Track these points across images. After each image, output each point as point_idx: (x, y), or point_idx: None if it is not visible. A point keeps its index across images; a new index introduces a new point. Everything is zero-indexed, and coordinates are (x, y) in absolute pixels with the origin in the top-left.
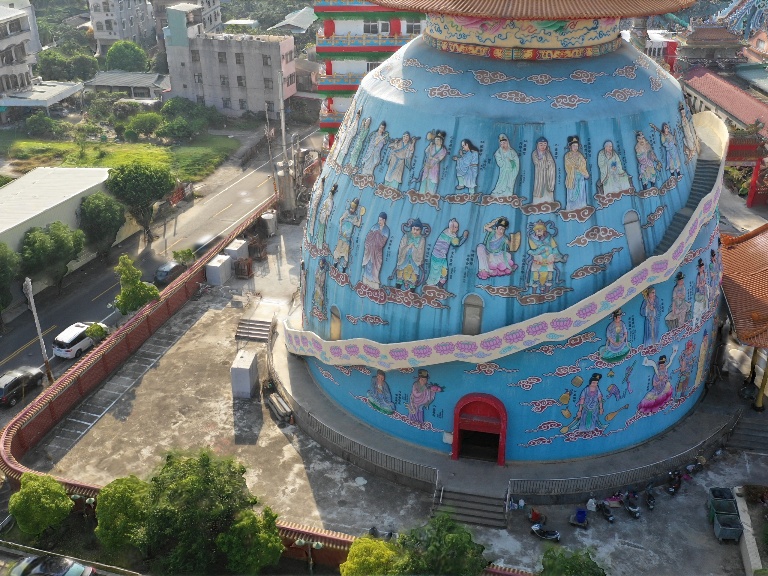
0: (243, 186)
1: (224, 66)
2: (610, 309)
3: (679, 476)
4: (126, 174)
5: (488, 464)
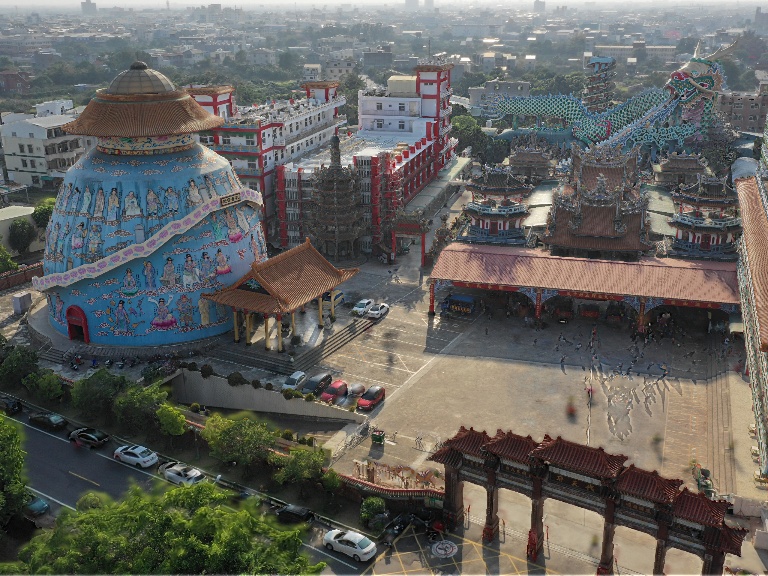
0: None
1: None
2: (114, 266)
3: (157, 357)
4: (42, 210)
5: (82, 343)
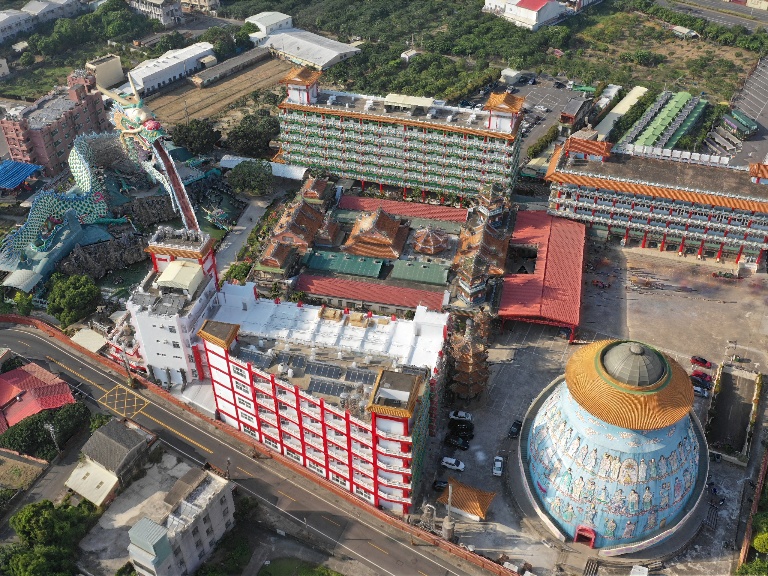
0: (386, 562)
1: (197, 535)
2: None
3: None
4: None
5: None
